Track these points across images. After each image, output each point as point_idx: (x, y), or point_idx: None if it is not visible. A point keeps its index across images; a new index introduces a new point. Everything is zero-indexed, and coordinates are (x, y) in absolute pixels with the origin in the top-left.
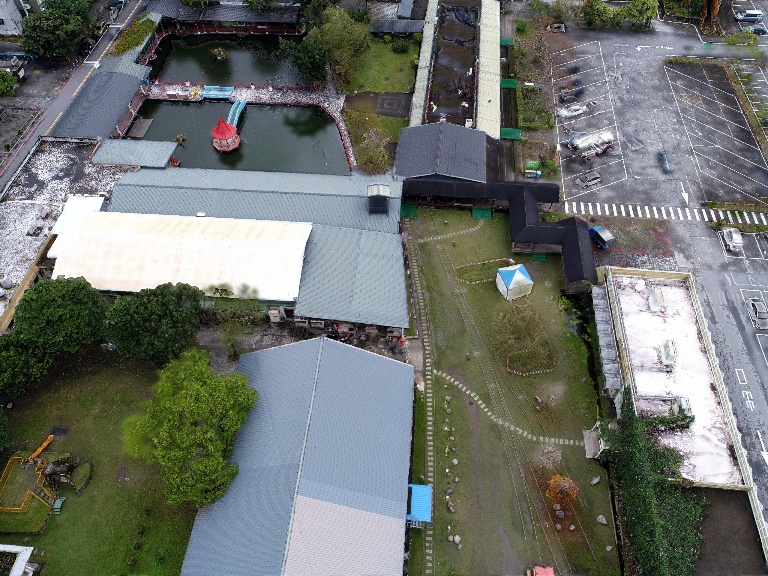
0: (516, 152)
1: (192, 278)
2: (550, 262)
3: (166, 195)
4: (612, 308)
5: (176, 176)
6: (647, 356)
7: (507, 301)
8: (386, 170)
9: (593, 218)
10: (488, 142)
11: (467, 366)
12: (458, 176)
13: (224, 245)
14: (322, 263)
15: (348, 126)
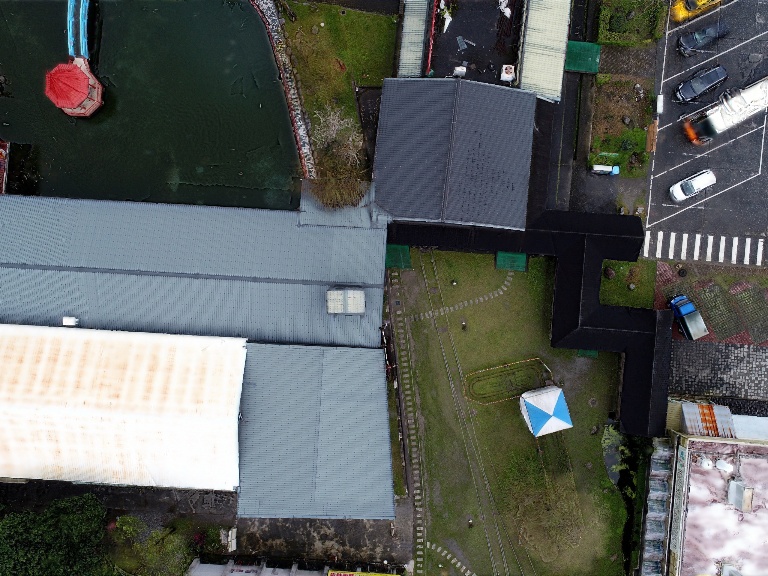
0: (584, 107)
1: (83, 462)
2: (602, 360)
3: (2, 280)
4: (675, 499)
5: (8, 227)
6: (703, 574)
7: (531, 434)
8: (359, 193)
9: (684, 271)
10: (538, 118)
11: (469, 536)
12: (479, 223)
13: (115, 419)
14: (268, 421)
15: (289, 44)
